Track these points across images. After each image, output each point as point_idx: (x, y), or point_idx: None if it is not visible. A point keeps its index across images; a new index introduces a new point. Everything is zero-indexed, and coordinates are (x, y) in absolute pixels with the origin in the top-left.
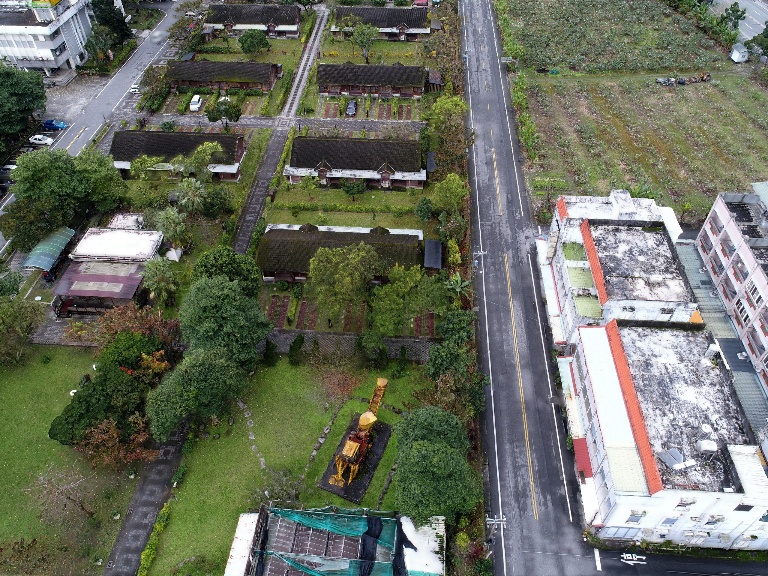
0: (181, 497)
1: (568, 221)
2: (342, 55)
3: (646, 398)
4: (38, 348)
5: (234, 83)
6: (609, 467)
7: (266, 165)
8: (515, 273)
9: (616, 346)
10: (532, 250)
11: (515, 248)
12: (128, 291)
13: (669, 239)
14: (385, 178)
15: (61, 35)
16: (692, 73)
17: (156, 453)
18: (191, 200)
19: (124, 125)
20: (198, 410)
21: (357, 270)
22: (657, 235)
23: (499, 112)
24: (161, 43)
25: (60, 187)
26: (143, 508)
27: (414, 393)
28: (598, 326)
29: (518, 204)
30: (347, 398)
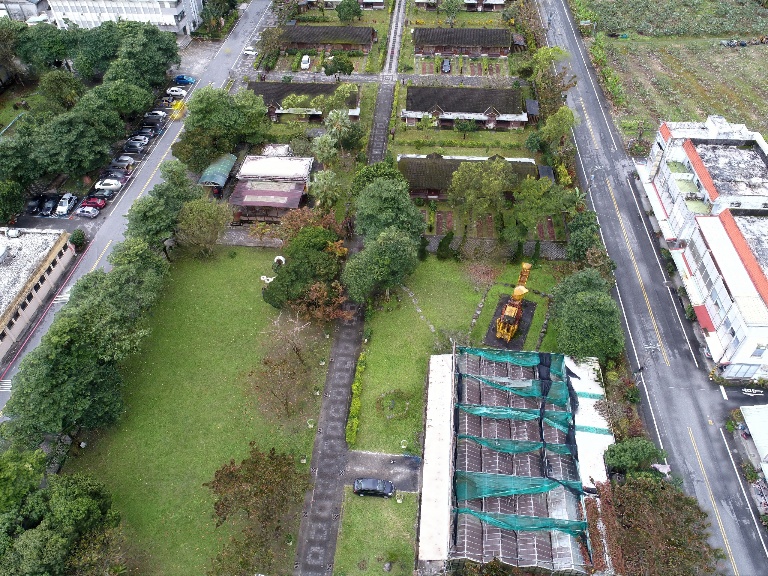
0: (371, 351)
1: (673, 141)
2: (427, 23)
3: (762, 263)
4: (222, 247)
5: (338, 45)
6: (739, 309)
7: (380, 111)
8: (618, 193)
9: (731, 228)
10: (630, 176)
11: (615, 174)
12: (293, 202)
13: (763, 153)
14: (490, 120)
15: (182, 3)
16: (751, 37)
17: (352, 313)
18: (338, 129)
19: (246, 80)
20: (386, 279)
21: (500, 176)
22: (750, 152)
23: (580, 69)
24: (260, 14)
25: (225, 119)
26: (342, 358)
27: (560, 269)
28: (712, 216)
29: (611, 141)
30: (492, 283)
